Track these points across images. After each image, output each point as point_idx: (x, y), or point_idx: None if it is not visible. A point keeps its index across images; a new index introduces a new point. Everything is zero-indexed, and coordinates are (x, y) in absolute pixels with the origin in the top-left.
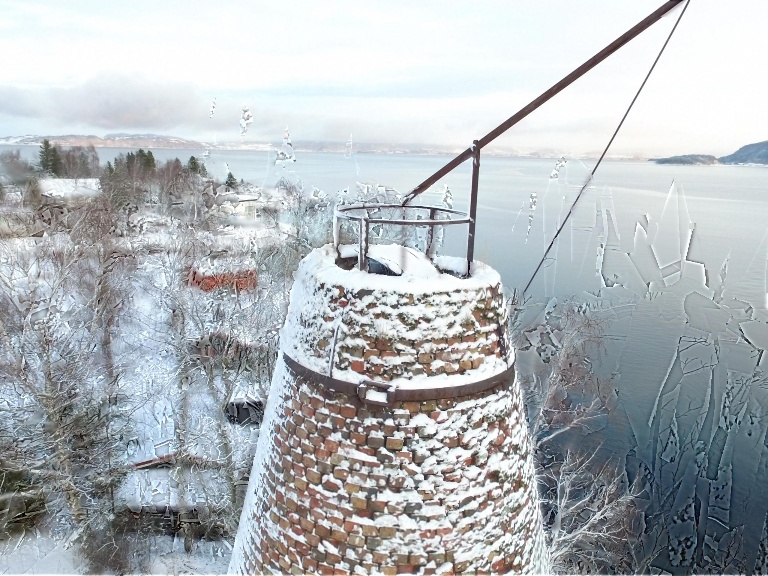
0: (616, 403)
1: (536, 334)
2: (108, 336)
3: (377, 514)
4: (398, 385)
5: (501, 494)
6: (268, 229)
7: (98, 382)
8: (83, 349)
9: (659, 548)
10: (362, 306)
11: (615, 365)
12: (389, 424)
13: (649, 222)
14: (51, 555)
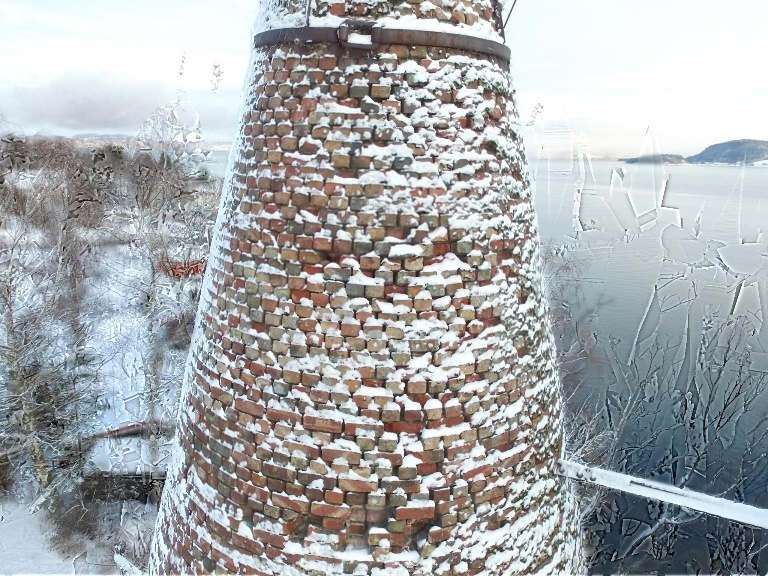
0: None
1: None
2: (73, 280)
3: (362, 171)
4: (384, 23)
5: (499, 170)
6: None
7: (63, 329)
8: (48, 301)
9: (654, 369)
10: None
11: (593, 308)
12: (374, 70)
13: (624, 175)
14: (16, 522)
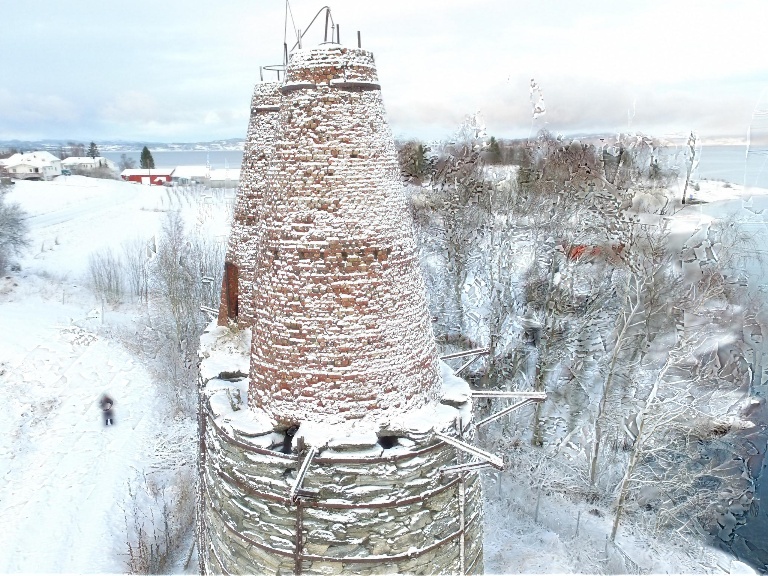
0: (766, 316)
1: (702, 249)
2: None
3: None
4: None
5: None
6: None
7: None
8: None
9: None
10: None
11: None
12: None
13: None
14: None
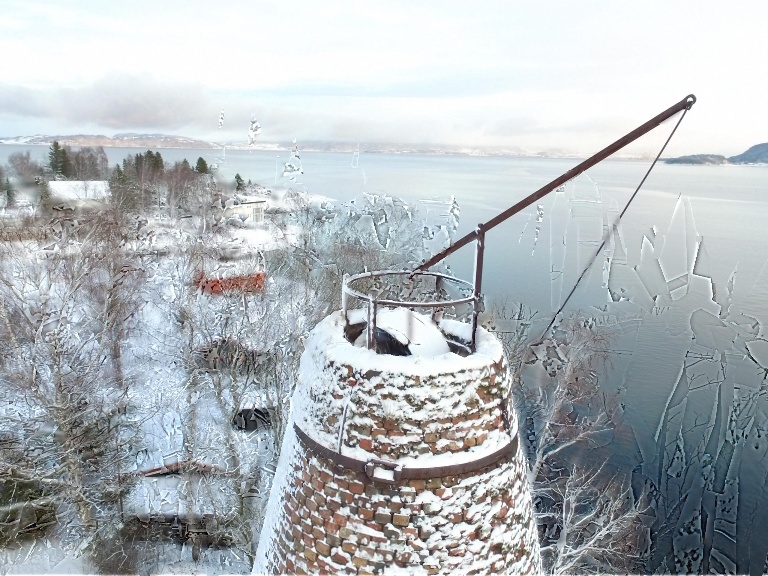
0: (622, 417)
1: (542, 348)
2: (118, 350)
3: None
4: (404, 464)
5: (504, 565)
6: (276, 242)
7: (108, 395)
8: (93, 361)
9: None
10: (370, 387)
11: (621, 379)
12: (396, 501)
13: (656, 234)
14: (61, 563)
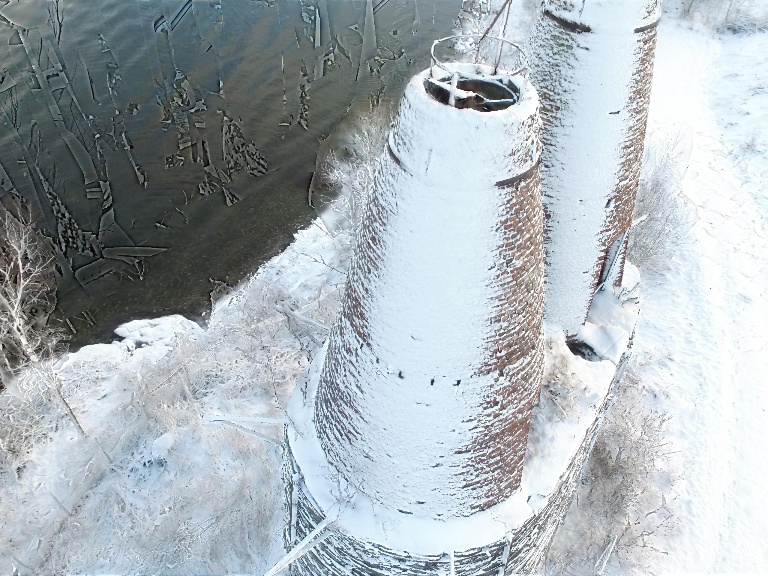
0: None
1: None
2: None
3: None
4: None
5: None
6: None
7: None
8: None
9: None
10: None
11: None
12: None
13: None
14: None
